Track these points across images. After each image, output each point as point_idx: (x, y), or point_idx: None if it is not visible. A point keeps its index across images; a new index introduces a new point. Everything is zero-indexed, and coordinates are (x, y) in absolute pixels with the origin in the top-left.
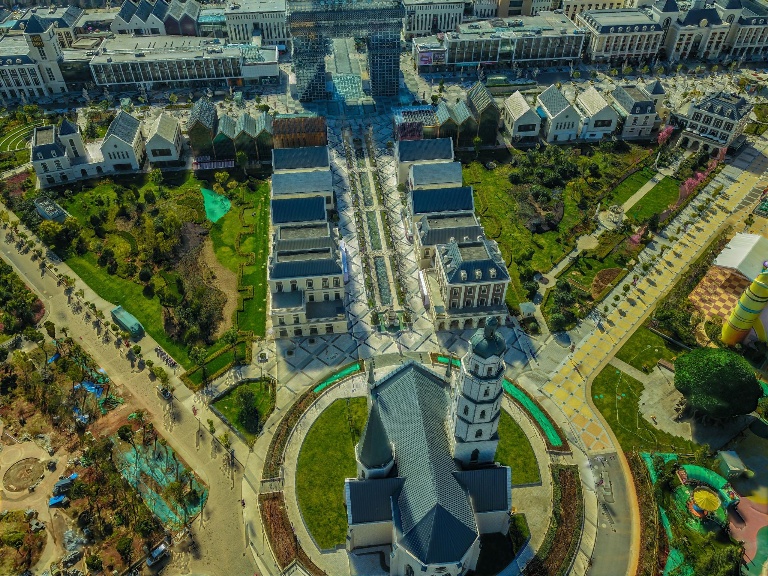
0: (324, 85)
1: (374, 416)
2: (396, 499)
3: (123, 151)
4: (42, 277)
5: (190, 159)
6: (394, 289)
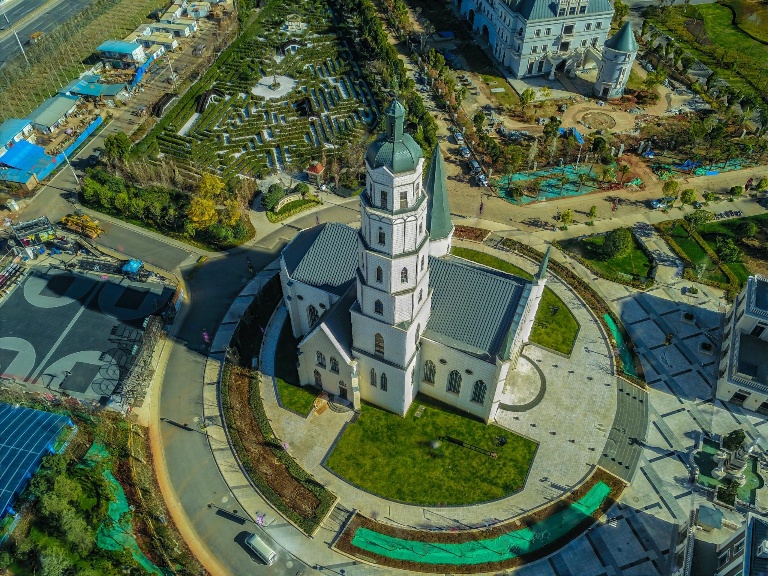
0: None
1: None
2: None
3: None
4: None
5: None
6: None
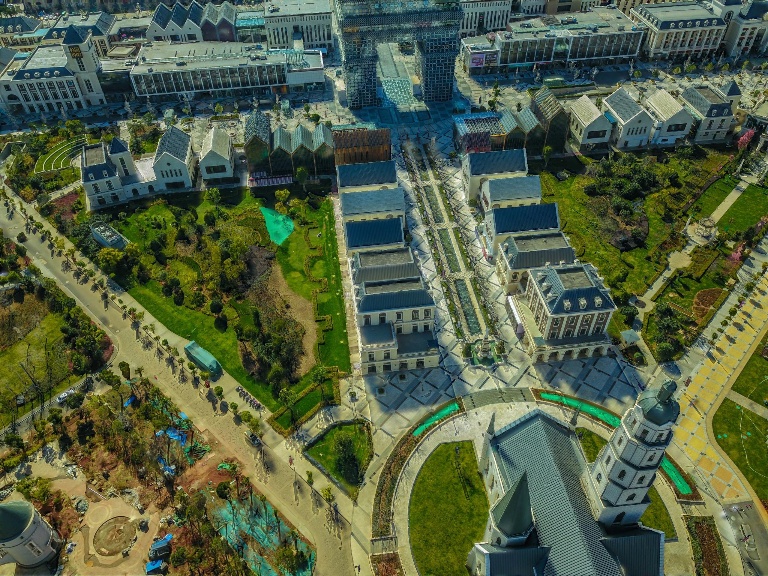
0: (375, 91)
1: (523, 485)
2: (541, 571)
3: (176, 169)
4: (106, 309)
5: (244, 175)
6: (481, 316)
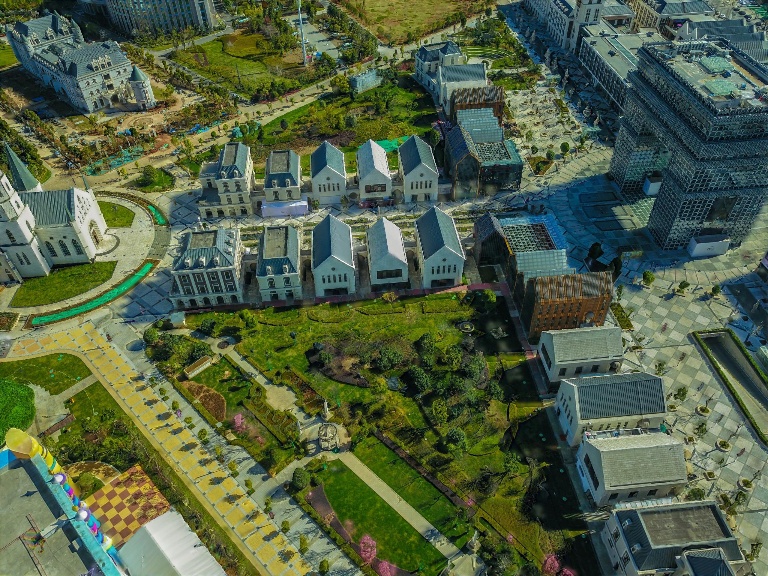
0: (626, 173)
1: None
2: None
3: None
4: None
5: None
6: (245, 242)
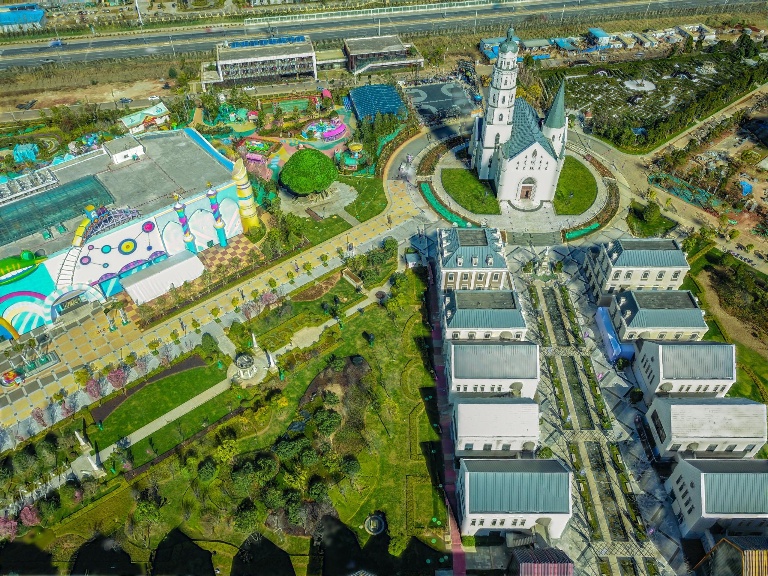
0: None
1: None
2: None
3: None
4: None
5: None
6: (542, 303)
